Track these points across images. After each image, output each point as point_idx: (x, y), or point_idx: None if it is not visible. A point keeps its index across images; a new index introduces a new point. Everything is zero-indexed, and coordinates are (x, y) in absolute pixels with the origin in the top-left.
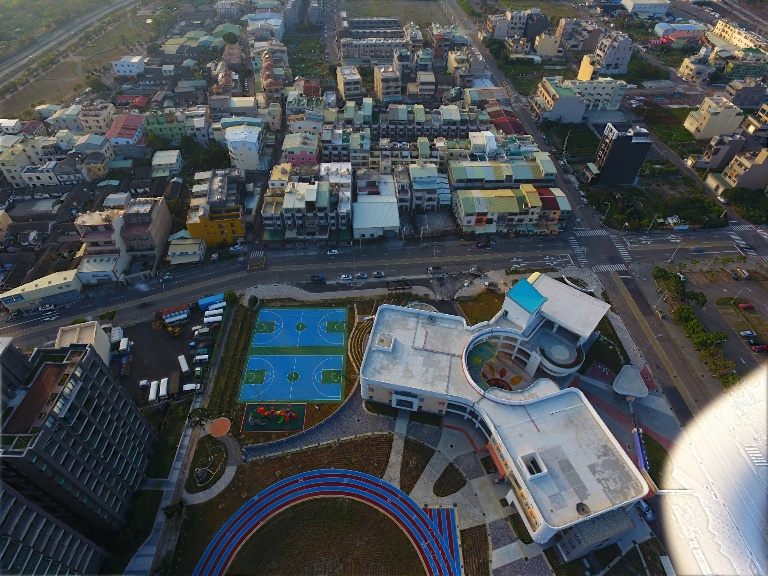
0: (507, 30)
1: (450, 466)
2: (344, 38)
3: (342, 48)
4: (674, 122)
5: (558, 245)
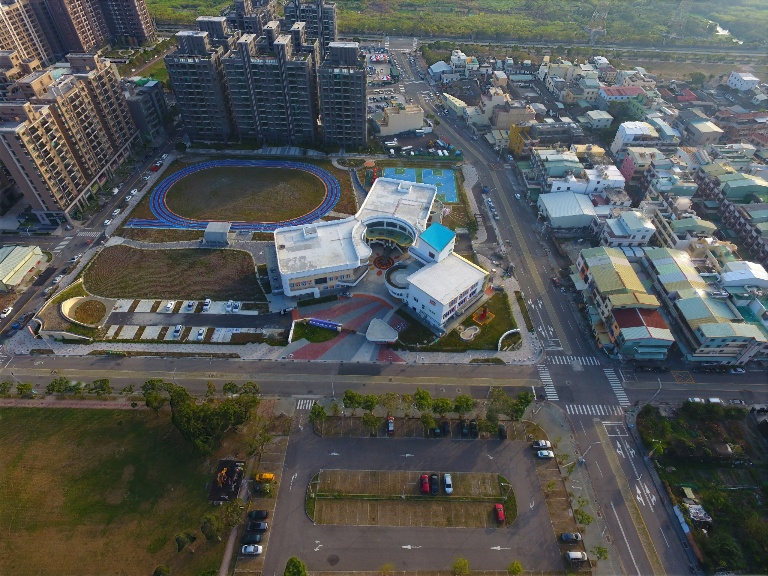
0: None
1: None
2: None
3: None
4: None
5: (577, 344)
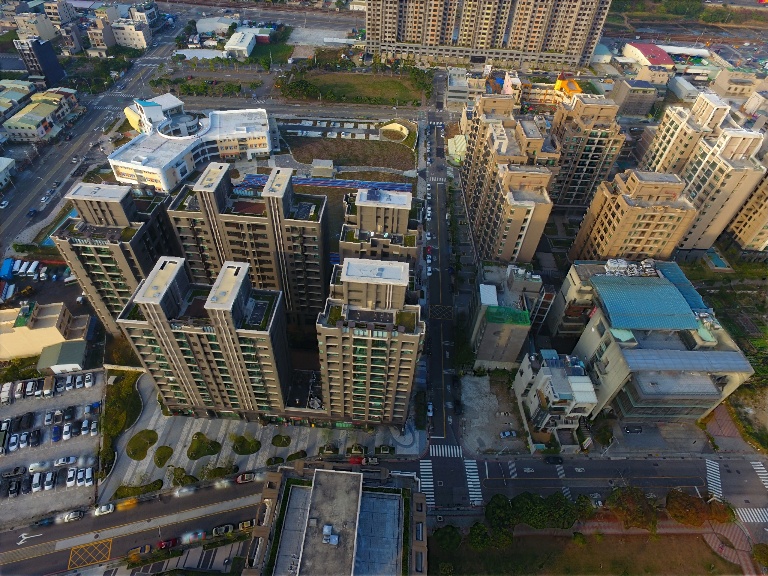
0: None
1: None
2: None
3: None
4: (13, 44)
5: (97, 113)
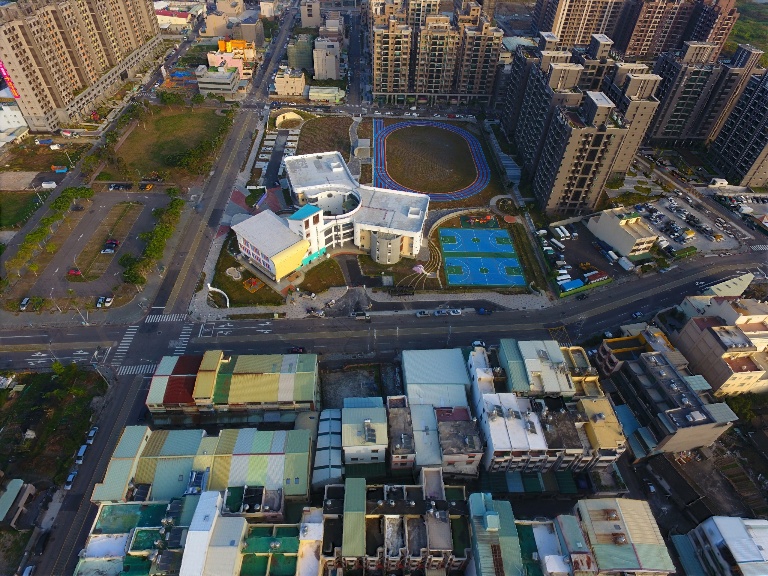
0: None
1: None
2: None
3: None
4: None
5: (201, 350)
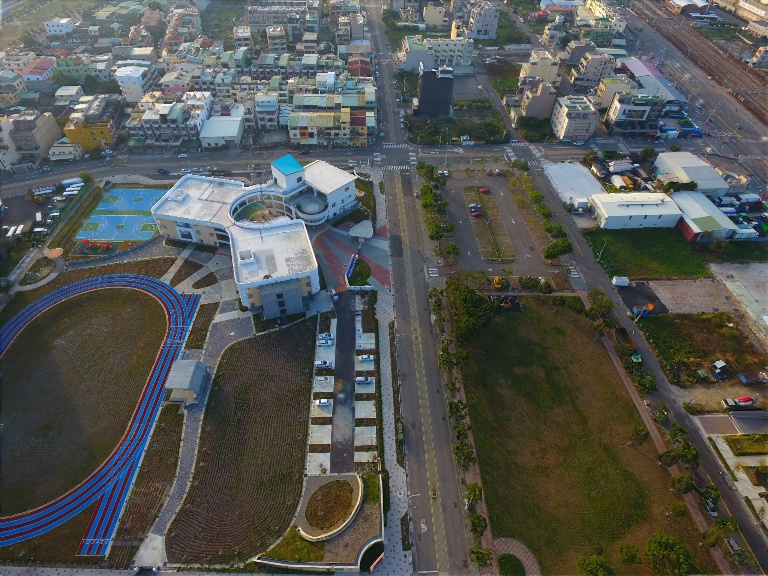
0: (404, 3)
1: (210, 274)
2: (250, 6)
3: (248, 14)
4: (513, 74)
5: (364, 153)
